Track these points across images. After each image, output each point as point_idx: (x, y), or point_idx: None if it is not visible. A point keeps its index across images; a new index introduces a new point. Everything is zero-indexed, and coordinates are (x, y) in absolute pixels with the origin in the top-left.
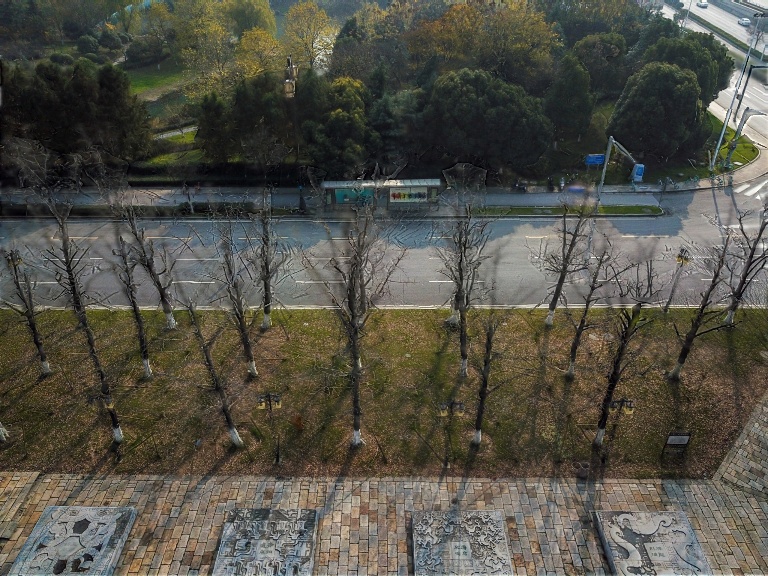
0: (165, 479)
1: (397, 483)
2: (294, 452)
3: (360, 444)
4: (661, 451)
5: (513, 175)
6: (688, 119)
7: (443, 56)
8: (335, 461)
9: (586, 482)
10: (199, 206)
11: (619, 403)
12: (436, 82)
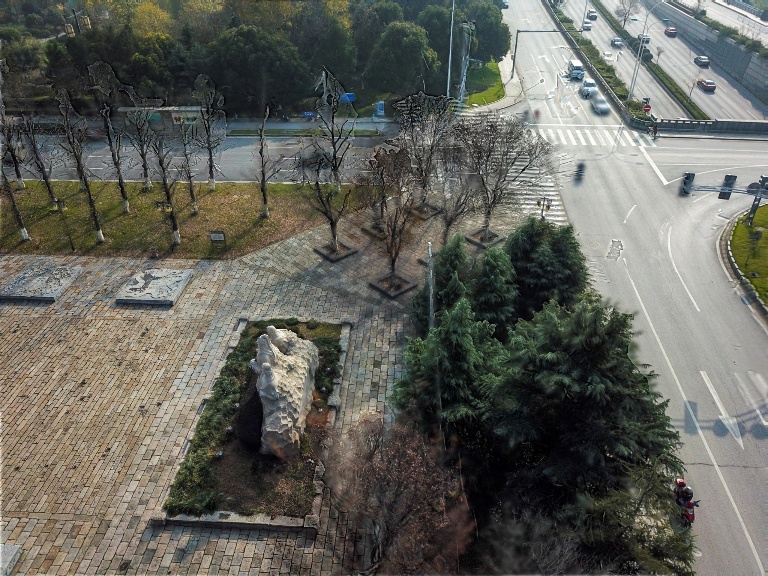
0: None
1: (36, 257)
2: None
3: (27, 240)
4: (213, 247)
5: (290, 111)
6: (420, 66)
7: None
8: (7, 247)
9: (153, 259)
10: None
11: (161, 204)
12: None
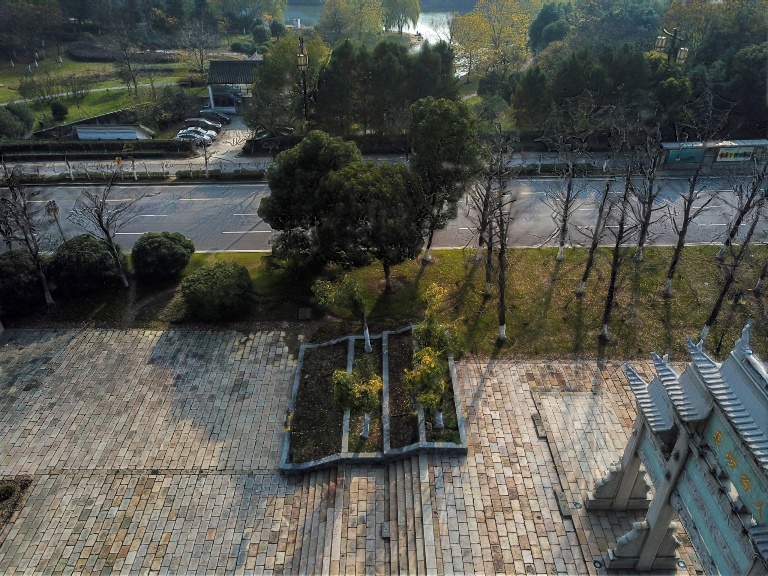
0: None
1: None
2: None
3: None
4: None
5: None
6: None
7: (685, 35)
8: None
9: None
10: (545, 167)
11: None
12: (740, 54)
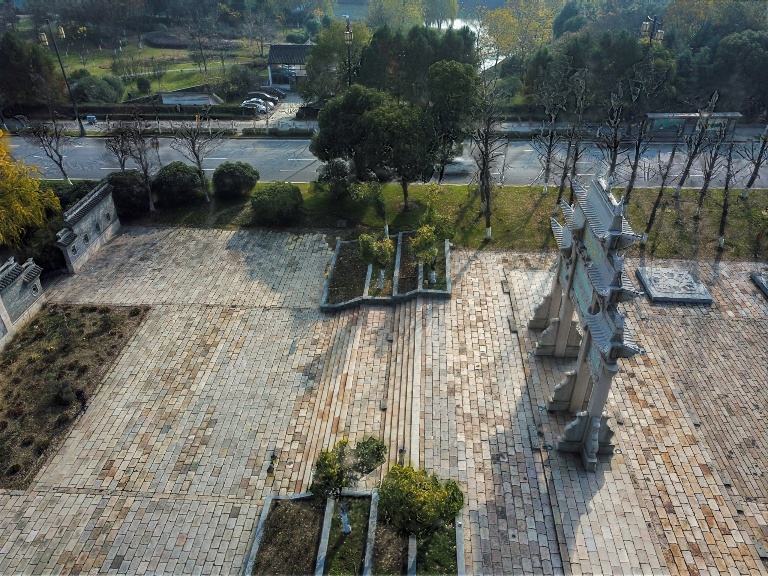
0: (691, 261)
1: None
2: (762, 252)
3: None
4: None
5: None
6: None
7: (687, 27)
8: None
9: None
10: (547, 132)
11: None
12: (723, 41)
